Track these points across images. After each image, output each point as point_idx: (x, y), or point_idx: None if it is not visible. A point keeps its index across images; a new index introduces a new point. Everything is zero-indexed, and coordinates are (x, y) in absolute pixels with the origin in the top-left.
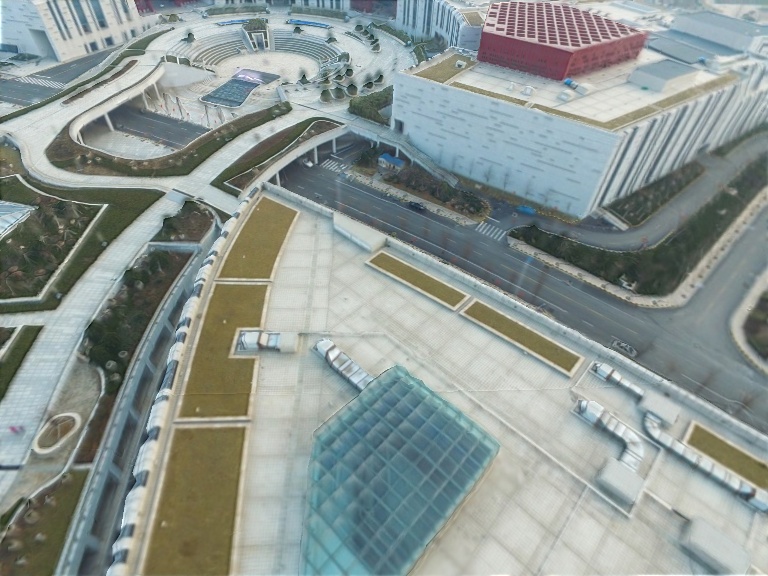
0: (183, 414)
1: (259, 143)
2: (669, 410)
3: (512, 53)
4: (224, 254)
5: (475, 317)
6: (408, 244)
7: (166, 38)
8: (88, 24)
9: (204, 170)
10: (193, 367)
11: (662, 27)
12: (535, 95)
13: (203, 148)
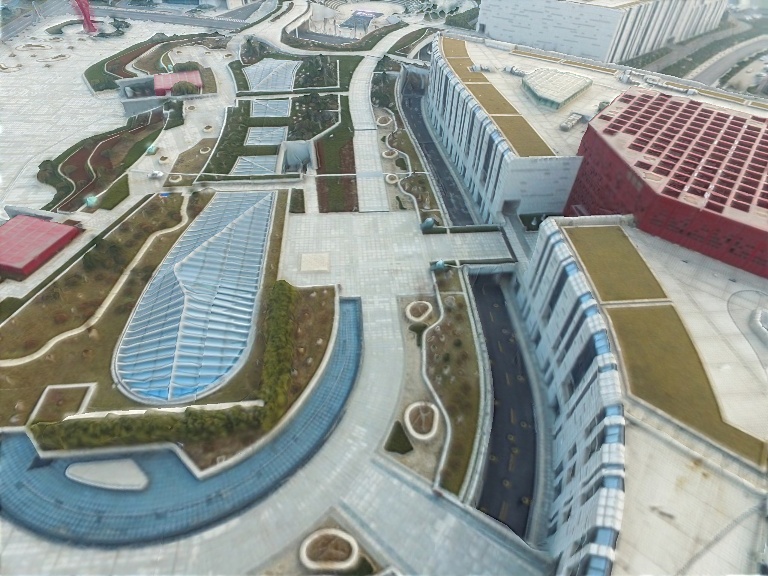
0: None
1: (403, 37)
2: (656, 77)
3: None
4: (442, 51)
5: (568, 63)
6: None
7: None
8: None
9: (379, 48)
10: (458, 74)
11: None
12: None
13: (372, 39)
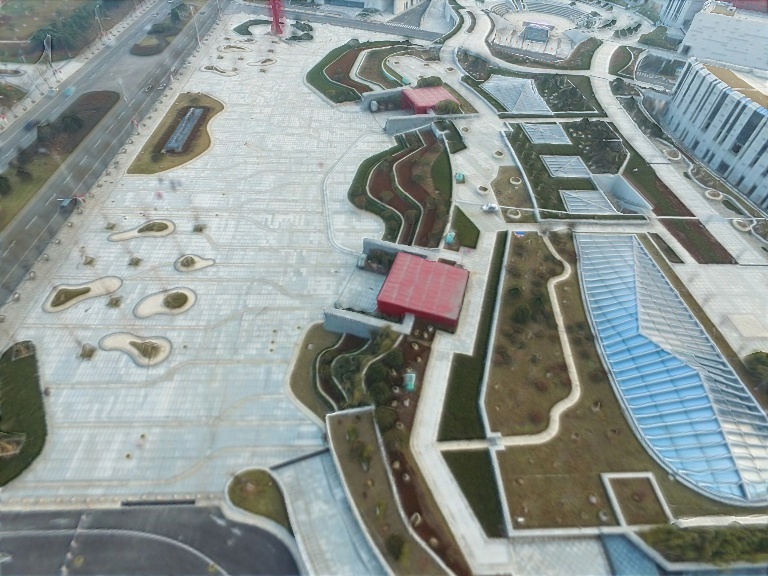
0: None
1: (612, 56)
2: None
3: (766, 2)
4: None
5: None
6: None
7: None
8: None
9: (596, 68)
10: None
11: None
12: None
13: (583, 57)
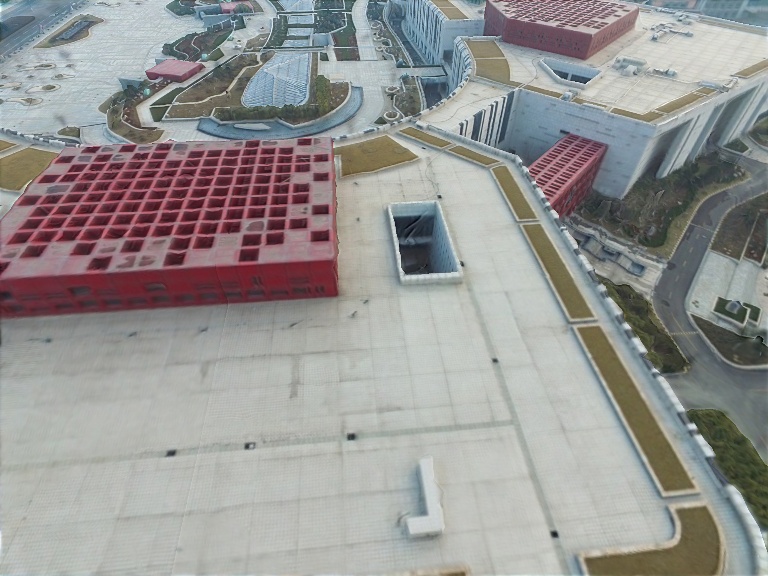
0: None
1: None
2: None
3: None
4: None
5: None
6: None
7: None
8: None
9: None
10: None
11: None
12: None
13: None
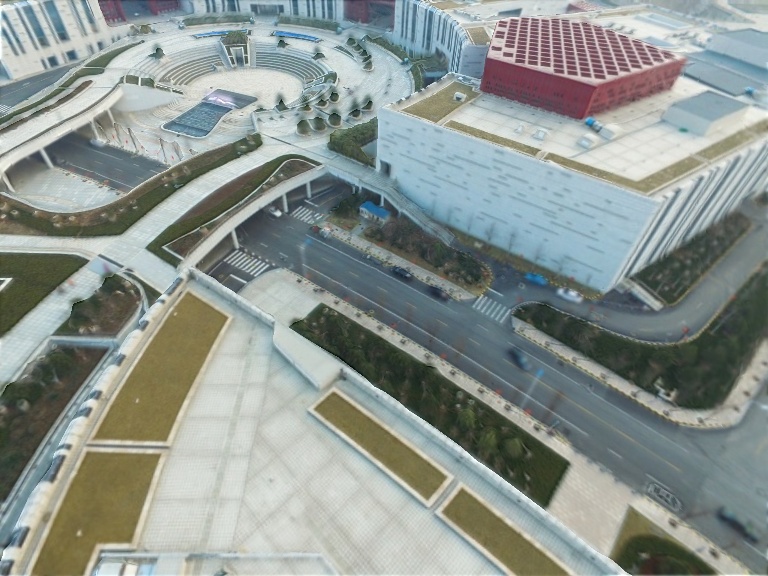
0: None
1: (215, 191)
2: None
3: (522, 84)
4: (111, 394)
5: (458, 523)
6: (388, 328)
7: (132, 53)
8: (45, 37)
9: (142, 228)
10: None
11: (697, 47)
12: (549, 140)
13: (146, 197)
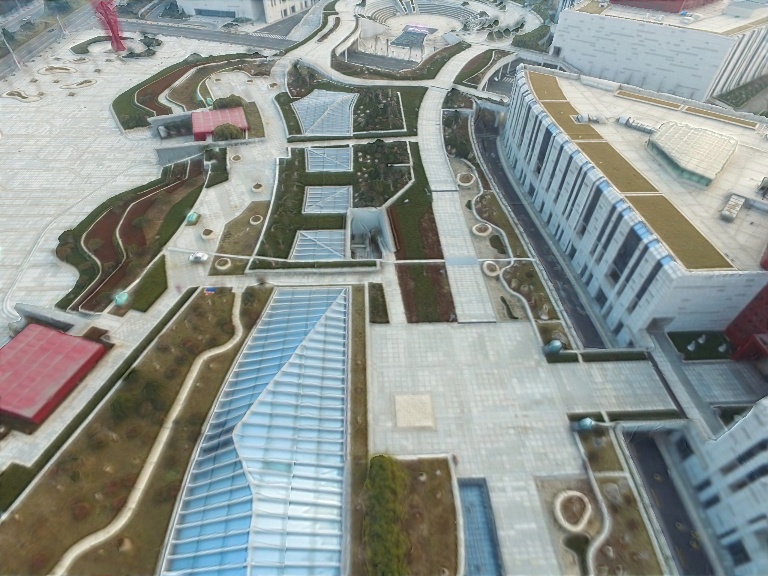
0: (573, 139)
1: (468, 62)
2: None
3: None
4: (533, 92)
5: (692, 111)
6: None
7: (342, 4)
8: None
9: (443, 76)
10: None
11: None
12: (665, 21)
13: (433, 65)
